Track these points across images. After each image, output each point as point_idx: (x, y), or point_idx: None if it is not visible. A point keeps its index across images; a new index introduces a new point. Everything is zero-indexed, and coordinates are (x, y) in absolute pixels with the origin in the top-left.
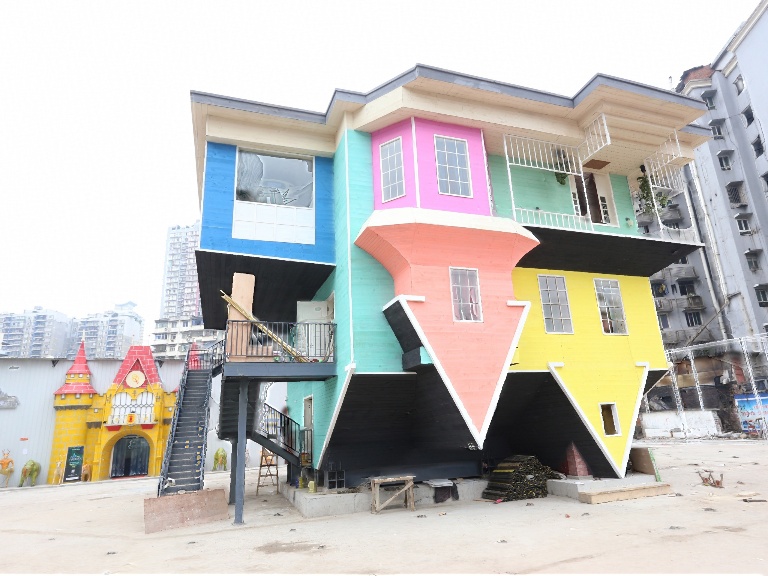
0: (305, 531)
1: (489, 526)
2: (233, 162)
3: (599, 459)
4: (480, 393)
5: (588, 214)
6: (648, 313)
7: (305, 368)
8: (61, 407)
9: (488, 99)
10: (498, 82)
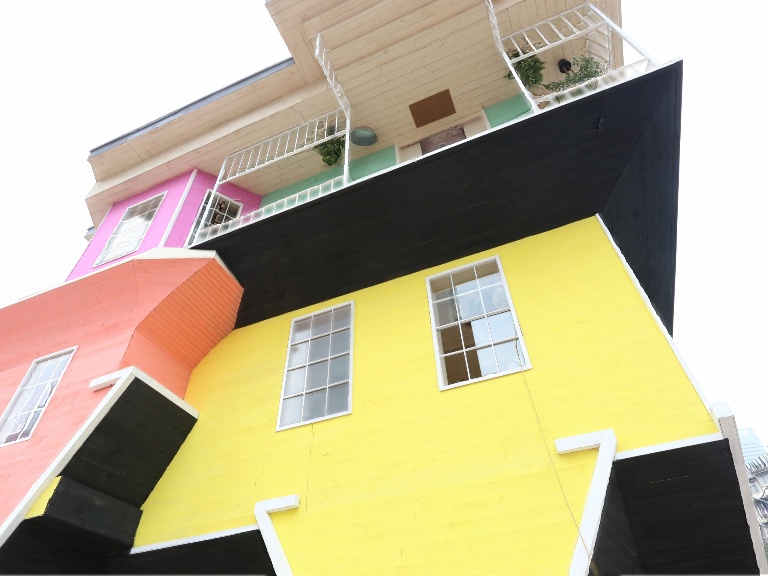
0: None
1: None
2: None
3: None
4: None
5: None
6: (603, 292)
7: None
8: None
9: (186, 132)
10: (183, 107)
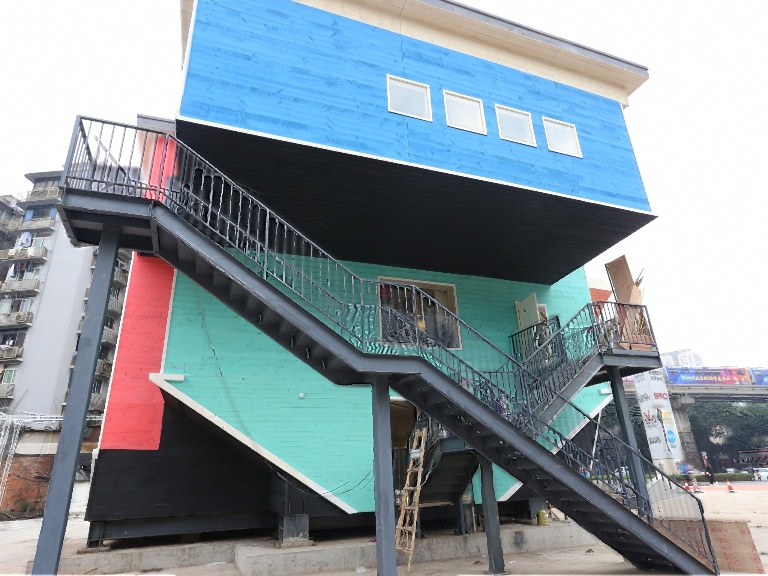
0: None
1: None
2: None
3: None
4: None
5: None
6: None
7: None
8: None
9: None
10: None
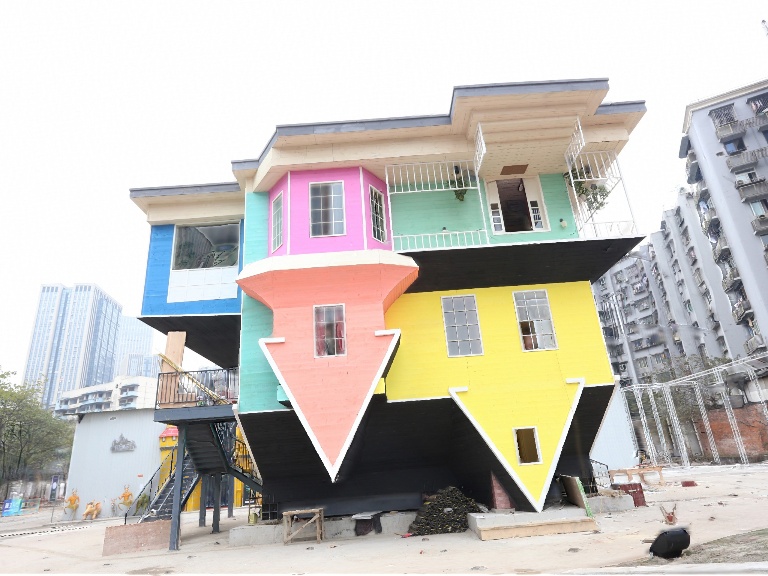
0: (196, 558)
1: (334, 560)
2: (171, 238)
3: (516, 490)
4: (338, 426)
5: (484, 227)
6: (587, 321)
7: (223, 410)
8: (163, 448)
9: (358, 138)
10: (361, 121)
